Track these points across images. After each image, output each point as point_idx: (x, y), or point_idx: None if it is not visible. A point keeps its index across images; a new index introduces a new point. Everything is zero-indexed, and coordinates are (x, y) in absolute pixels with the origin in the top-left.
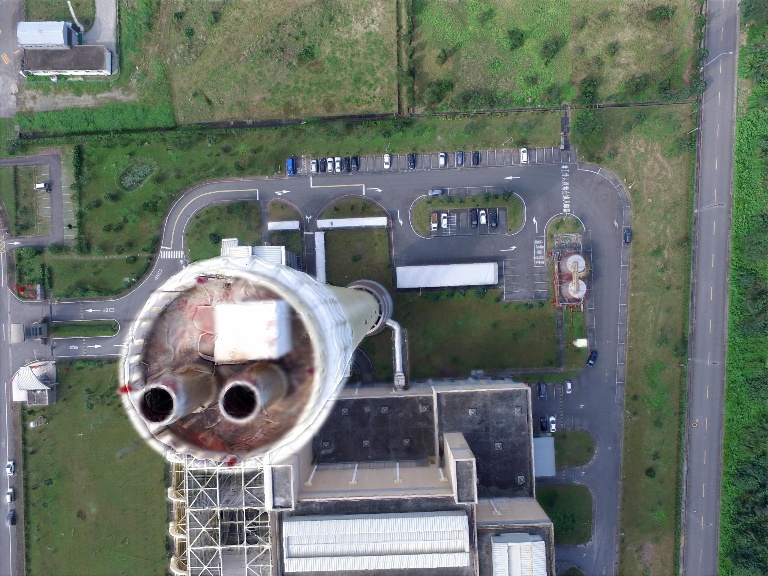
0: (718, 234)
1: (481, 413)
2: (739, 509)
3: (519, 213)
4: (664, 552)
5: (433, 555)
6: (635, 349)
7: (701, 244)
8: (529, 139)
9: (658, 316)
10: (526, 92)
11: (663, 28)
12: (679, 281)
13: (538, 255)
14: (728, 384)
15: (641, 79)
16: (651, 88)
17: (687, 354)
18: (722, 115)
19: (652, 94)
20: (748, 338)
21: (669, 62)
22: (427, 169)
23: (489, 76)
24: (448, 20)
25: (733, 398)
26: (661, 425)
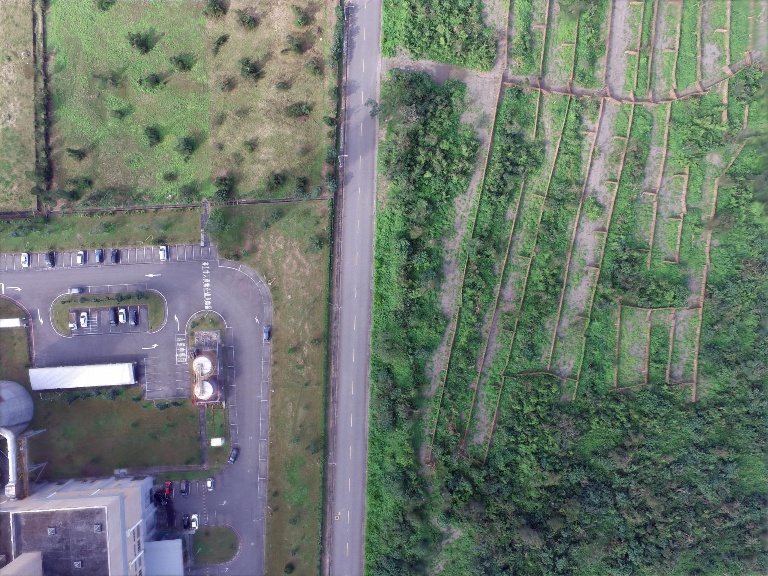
0: (359, 329)
1: (61, 531)
2: None
3: (160, 311)
4: None
5: None
6: (276, 445)
7: (342, 339)
8: (169, 236)
9: (297, 412)
10: (166, 189)
11: (302, 124)
12: (319, 377)
13: (180, 353)
14: (368, 477)
15: (270, 178)
16: (290, 184)
17: (328, 449)
18: (362, 210)
19: (291, 190)
20: None
21: (308, 158)
22: (67, 267)
23: (129, 173)
24: (86, 116)
25: (372, 491)
26: (294, 522)
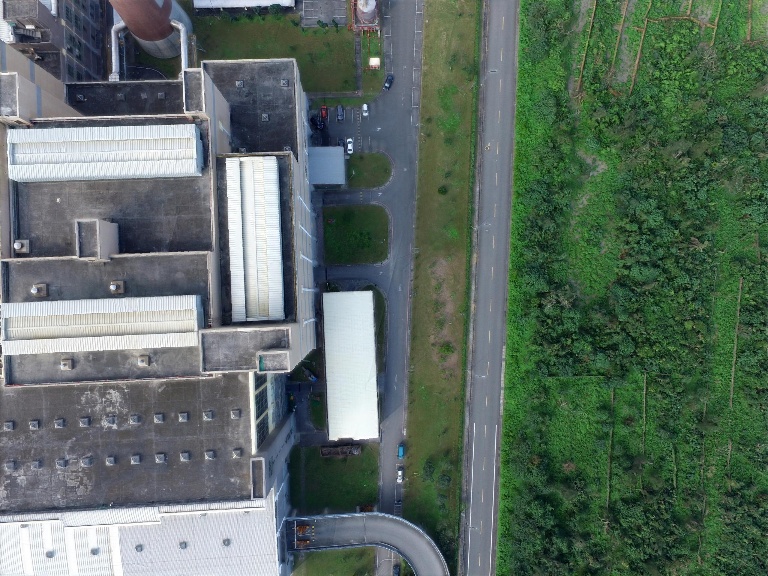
0: None
1: (249, 86)
2: (527, 227)
3: None
4: (457, 269)
5: (160, 161)
6: (430, 74)
7: None
8: None
9: (451, 42)
10: None
11: None
12: (471, 9)
13: None
14: (517, 109)
15: None
16: None
17: (479, 80)
18: None
19: None
20: (536, 65)
21: None
22: None
23: None
24: None
25: (522, 121)
26: (450, 140)
